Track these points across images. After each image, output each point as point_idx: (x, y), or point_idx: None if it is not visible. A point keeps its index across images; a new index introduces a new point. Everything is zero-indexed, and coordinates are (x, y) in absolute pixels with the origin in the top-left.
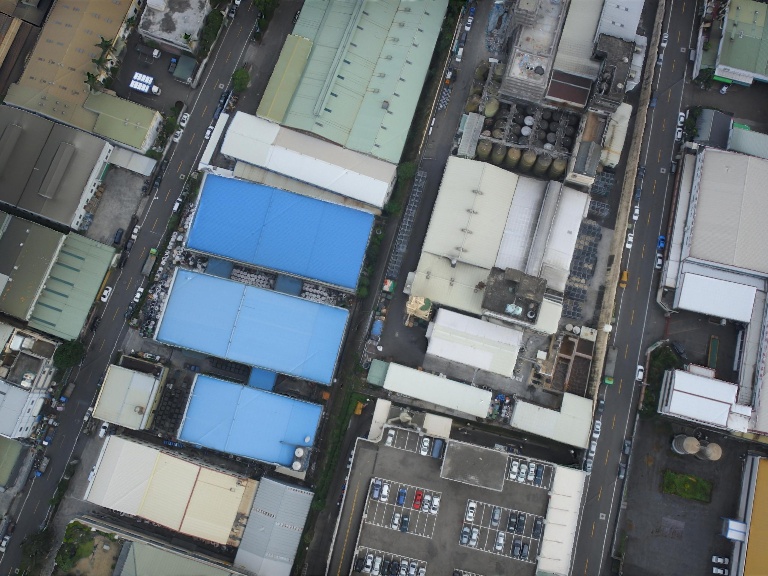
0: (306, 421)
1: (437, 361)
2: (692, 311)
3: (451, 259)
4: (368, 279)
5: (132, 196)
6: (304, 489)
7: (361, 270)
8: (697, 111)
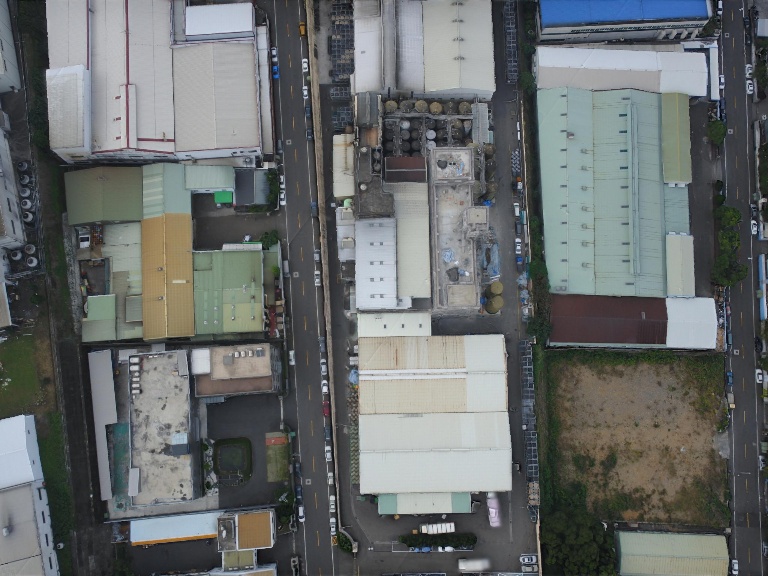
0: None
1: None
2: None
3: None
4: None
5: (764, 4)
6: None
7: None
8: (272, 198)
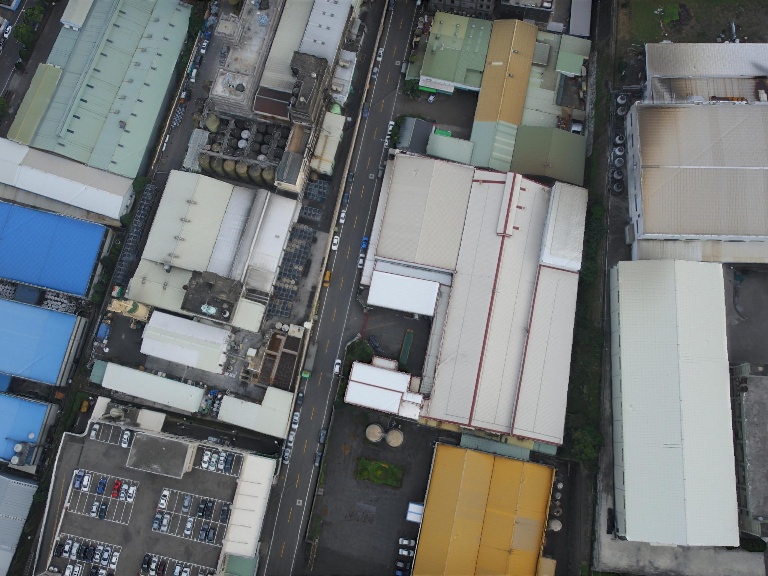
0: (32, 419)
1: (158, 360)
2: (382, 307)
3: (164, 265)
4: (103, 286)
5: None
6: (29, 482)
7: (99, 278)
8: (399, 120)
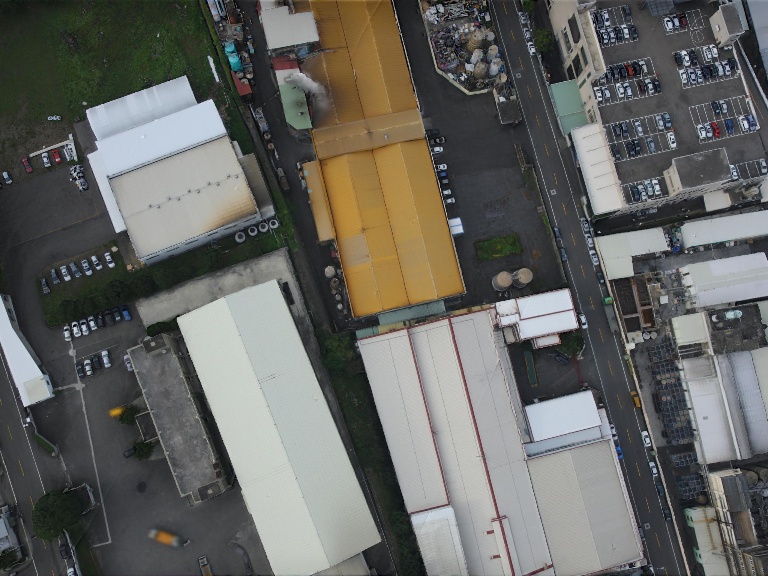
0: None
1: None
2: None
3: None
4: None
5: None
6: None
7: None
8: None
